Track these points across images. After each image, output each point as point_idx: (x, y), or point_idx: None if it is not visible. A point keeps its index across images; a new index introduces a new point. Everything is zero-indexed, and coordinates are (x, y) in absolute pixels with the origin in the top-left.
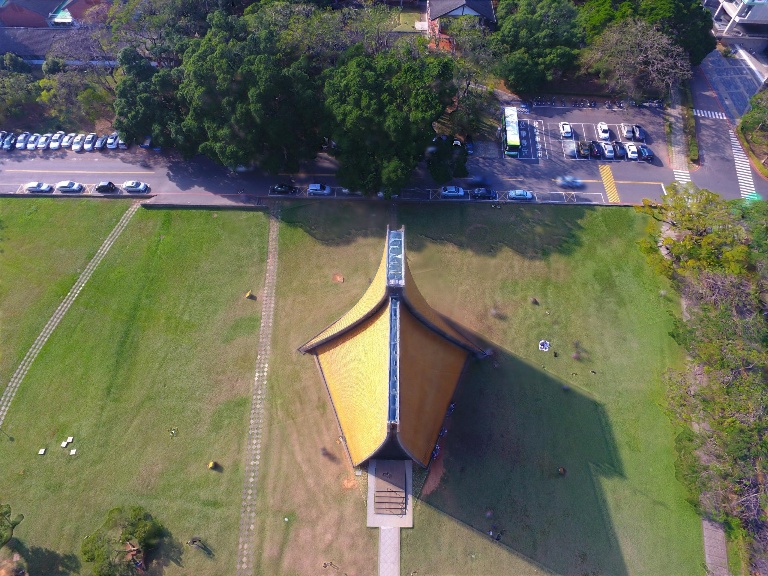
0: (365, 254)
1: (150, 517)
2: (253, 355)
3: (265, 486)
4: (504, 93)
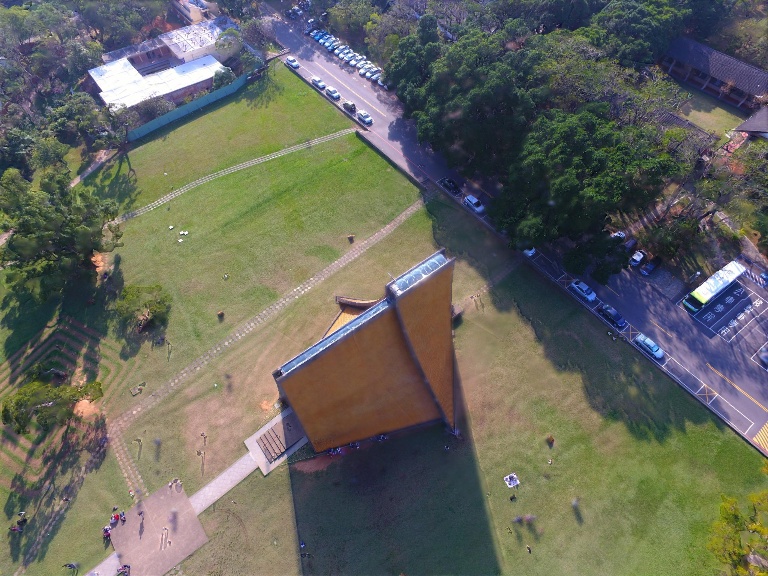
0: (455, 277)
1: (169, 309)
2: (310, 275)
3: (228, 354)
4: (755, 249)
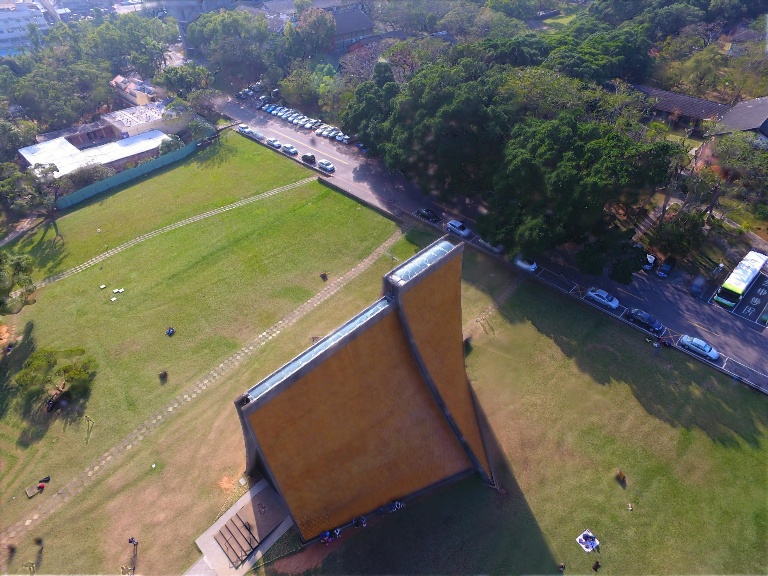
0: None
1: (93, 377)
2: (278, 318)
3: (172, 423)
4: (765, 242)
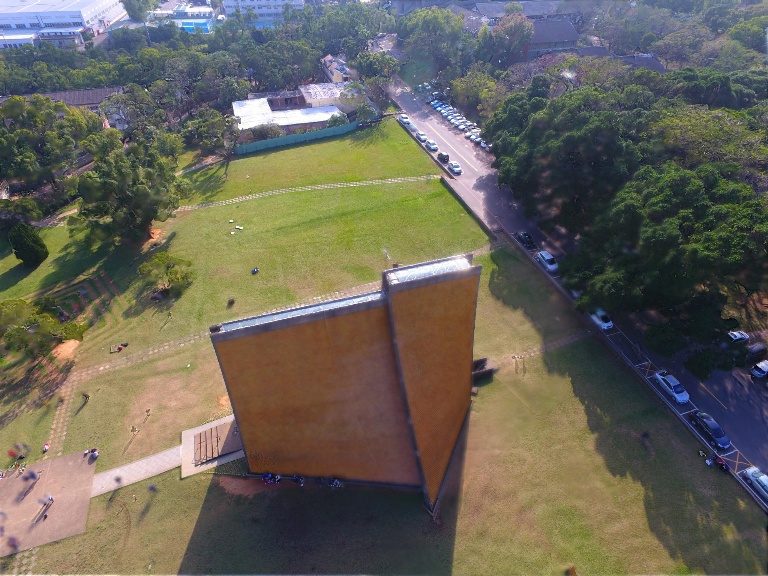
0: (500, 331)
1: (189, 285)
2: (337, 288)
3: None
4: None
